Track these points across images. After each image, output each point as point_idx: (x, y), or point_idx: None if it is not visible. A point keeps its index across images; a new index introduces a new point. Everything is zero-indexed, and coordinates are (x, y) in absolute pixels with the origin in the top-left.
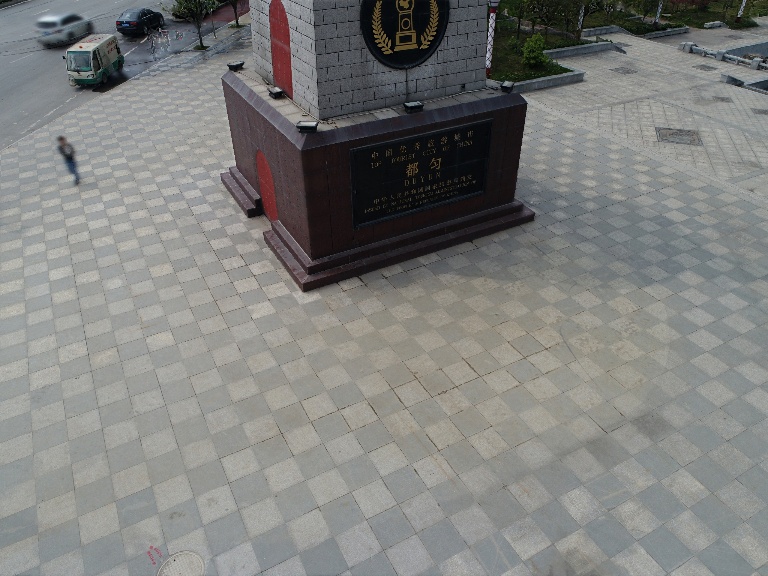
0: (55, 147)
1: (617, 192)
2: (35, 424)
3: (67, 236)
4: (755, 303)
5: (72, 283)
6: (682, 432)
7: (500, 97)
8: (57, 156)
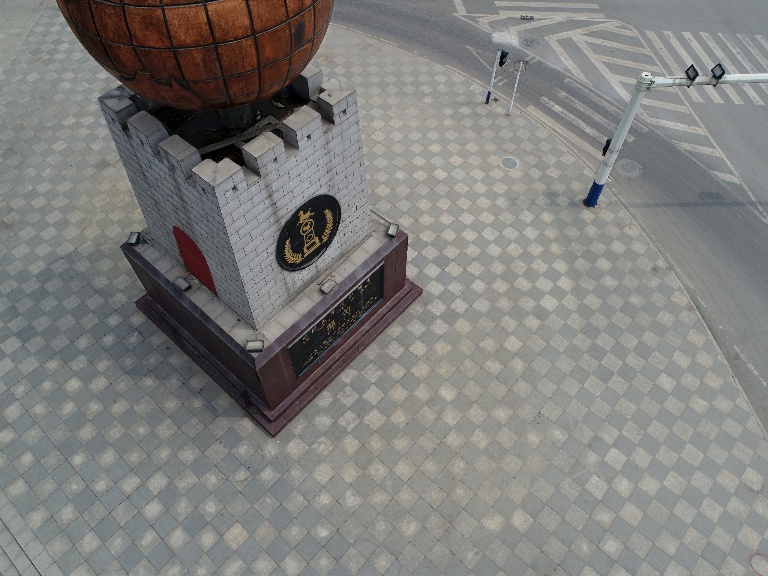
0: (645, 315)
1: (51, 373)
2: (361, 109)
3: (473, 202)
4: (7, 252)
5: (424, 169)
6: (90, 165)
7: (142, 231)
8: (619, 299)
